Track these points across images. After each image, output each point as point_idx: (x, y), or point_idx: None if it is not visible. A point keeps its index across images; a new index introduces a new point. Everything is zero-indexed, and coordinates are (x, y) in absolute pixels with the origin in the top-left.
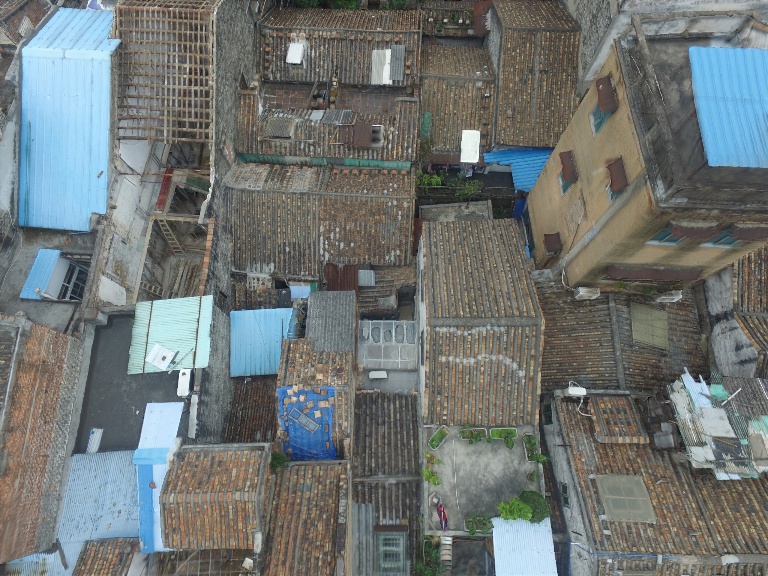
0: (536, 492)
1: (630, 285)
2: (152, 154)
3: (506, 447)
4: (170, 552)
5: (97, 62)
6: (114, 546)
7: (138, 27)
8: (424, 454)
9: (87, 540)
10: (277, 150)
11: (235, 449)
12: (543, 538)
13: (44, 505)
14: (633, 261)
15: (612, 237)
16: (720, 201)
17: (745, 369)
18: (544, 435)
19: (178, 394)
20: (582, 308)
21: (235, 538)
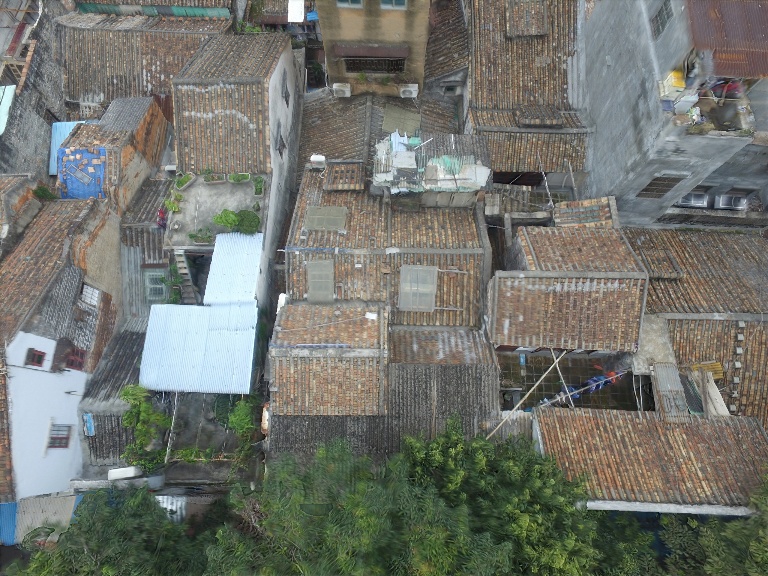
0: None
1: (371, 77)
2: (4, 6)
3: (242, 190)
4: None
5: None
6: None
7: None
8: None
9: None
10: None
11: None
12: (255, 246)
13: None
14: (348, 36)
15: None
16: None
17: None
18: None
19: None
20: (348, 111)
21: None
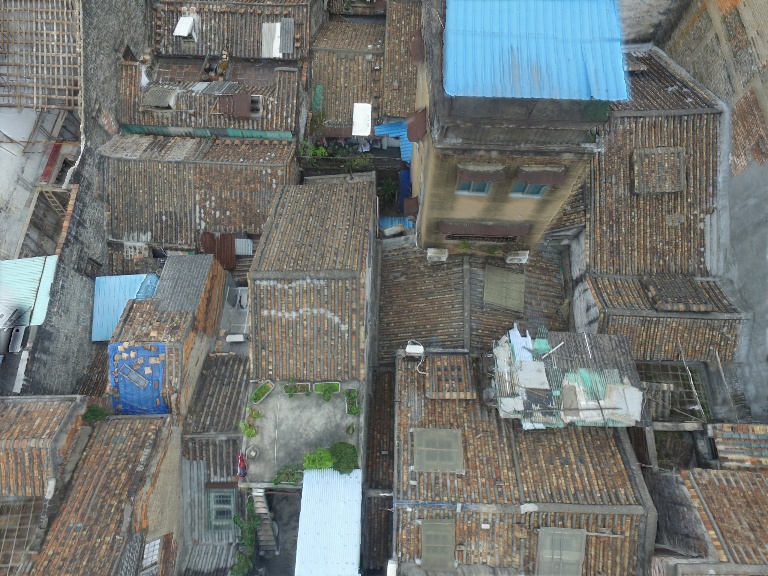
0: (347, 443)
1: (474, 245)
2: (39, 126)
3: (331, 402)
4: None
5: None
6: None
7: None
8: None
9: None
10: (159, 121)
11: (47, 400)
12: (352, 489)
13: None
14: (458, 215)
15: (427, 189)
16: (495, 142)
17: (591, 329)
18: (394, 397)
19: (9, 350)
20: (440, 271)
21: (31, 485)
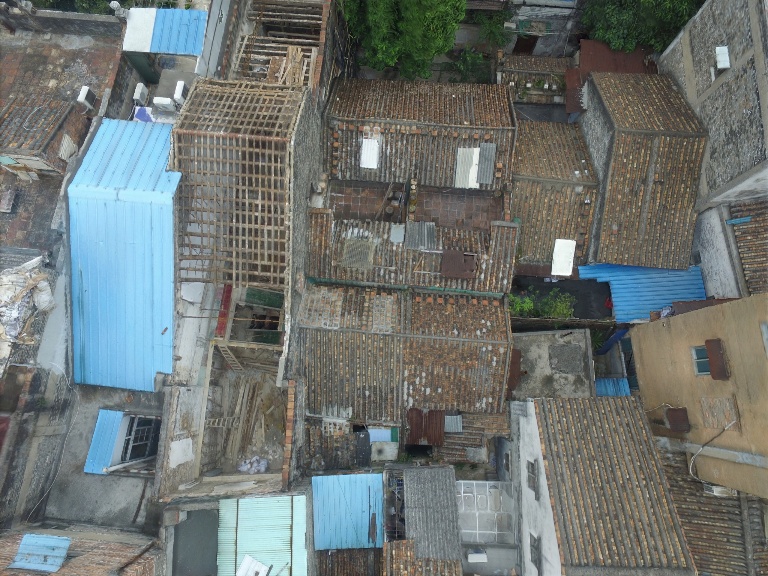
0: None
1: None
2: None
3: None
4: None
5: (157, 206)
6: None
7: (200, 155)
8: None
9: None
10: (353, 275)
11: None
12: None
13: None
14: None
15: None
16: None
17: None
18: None
19: None
20: None
21: None
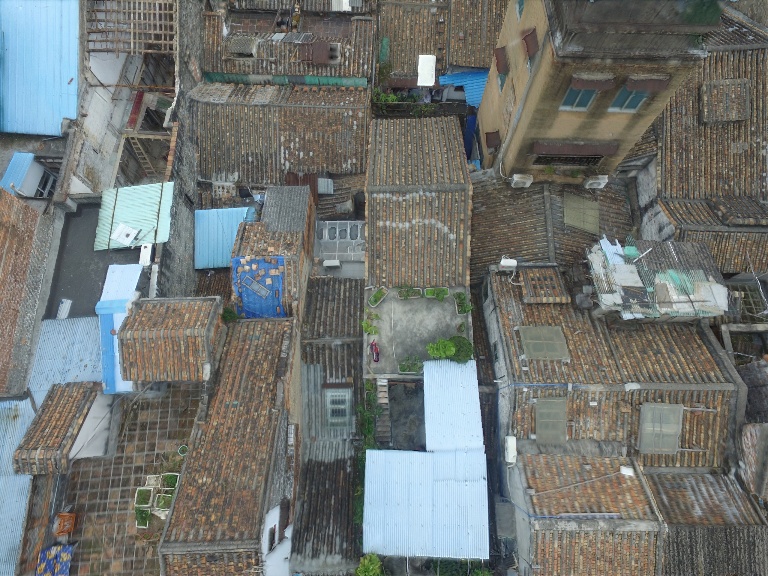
0: (463, 337)
1: (559, 169)
2: (123, 76)
3: (440, 306)
4: (133, 403)
5: None
6: (79, 387)
7: None
8: (364, 312)
9: (55, 384)
10: (241, 69)
11: (189, 301)
12: (469, 377)
13: (15, 354)
14: (554, 135)
15: (531, 107)
16: (613, 50)
17: None
18: (483, 312)
19: None
20: (520, 200)
21: (187, 370)
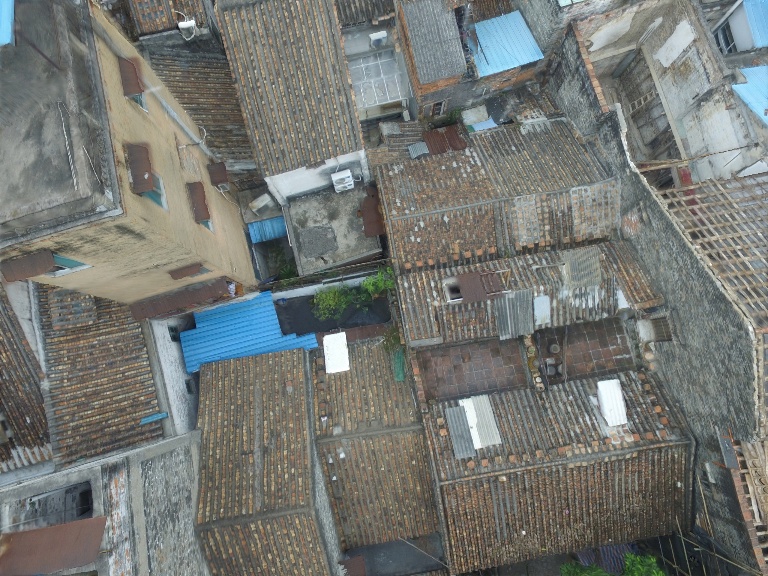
0: None
1: None
2: None
3: None
4: None
5: None
6: None
7: None
8: None
9: None
10: None
11: None
12: None
13: None
14: None
15: None
16: None
17: None
18: None
19: None
20: None
21: None
